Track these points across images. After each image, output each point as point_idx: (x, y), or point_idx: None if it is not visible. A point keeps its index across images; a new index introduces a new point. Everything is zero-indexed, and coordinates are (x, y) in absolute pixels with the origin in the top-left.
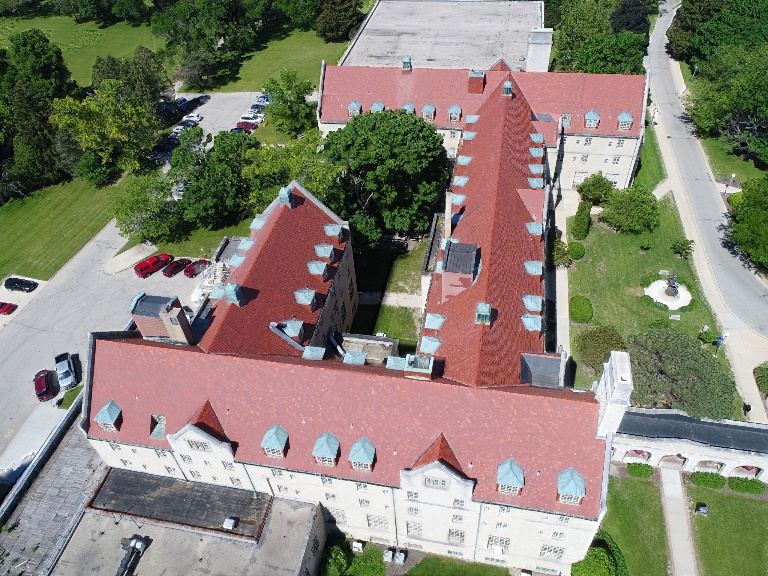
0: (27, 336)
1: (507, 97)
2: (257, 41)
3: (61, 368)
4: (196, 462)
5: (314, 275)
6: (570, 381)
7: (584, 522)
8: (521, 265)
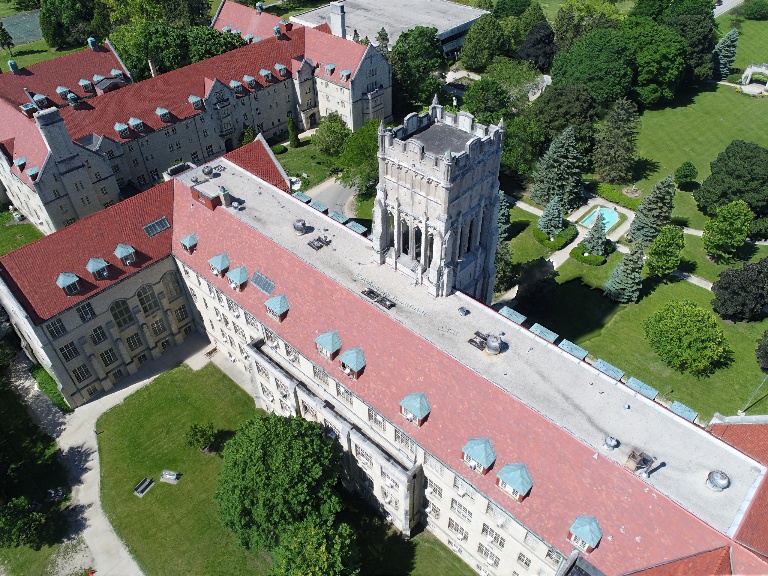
0: None
1: (275, 36)
2: (319, 2)
3: None
4: None
5: (80, 85)
6: None
7: (36, 195)
8: (153, 106)
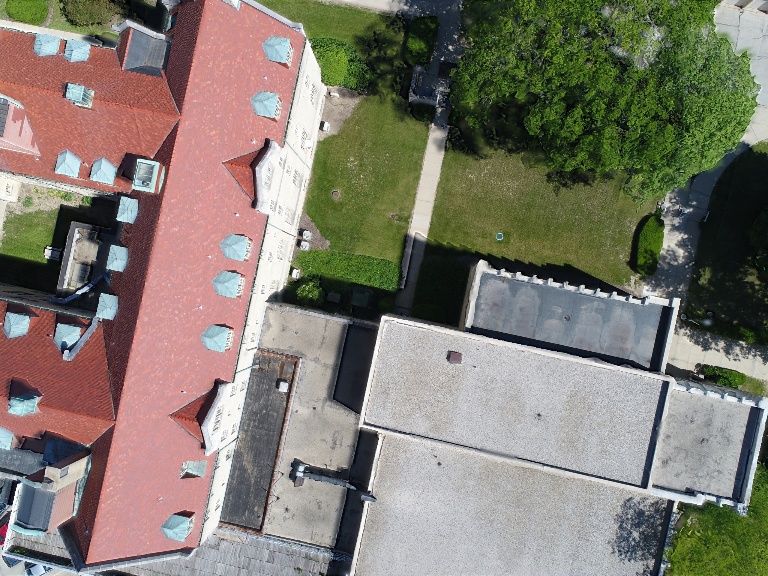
0: None
1: None
2: None
3: None
4: (227, 426)
5: None
6: None
7: (304, 51)
8: None
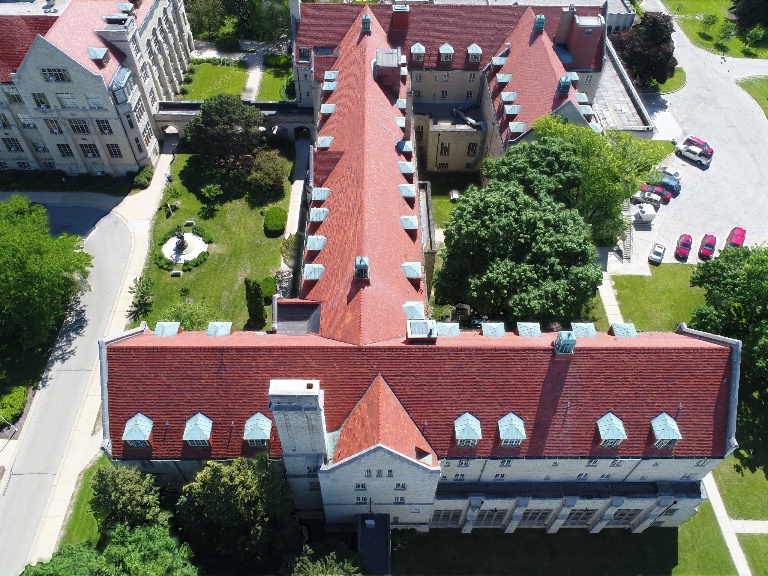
0: (766, 178)
1: None
2: None
3: (695, 148)
4: None
5: None
6: (296, 166)
7: None
8: None
